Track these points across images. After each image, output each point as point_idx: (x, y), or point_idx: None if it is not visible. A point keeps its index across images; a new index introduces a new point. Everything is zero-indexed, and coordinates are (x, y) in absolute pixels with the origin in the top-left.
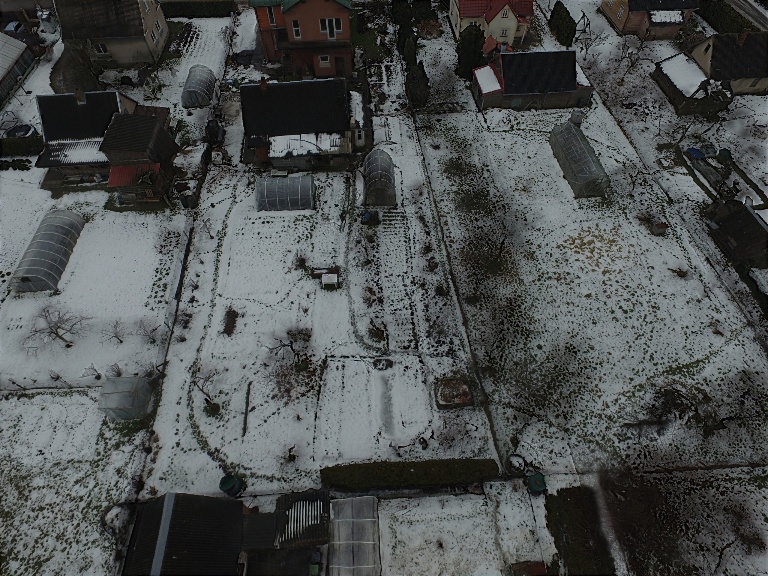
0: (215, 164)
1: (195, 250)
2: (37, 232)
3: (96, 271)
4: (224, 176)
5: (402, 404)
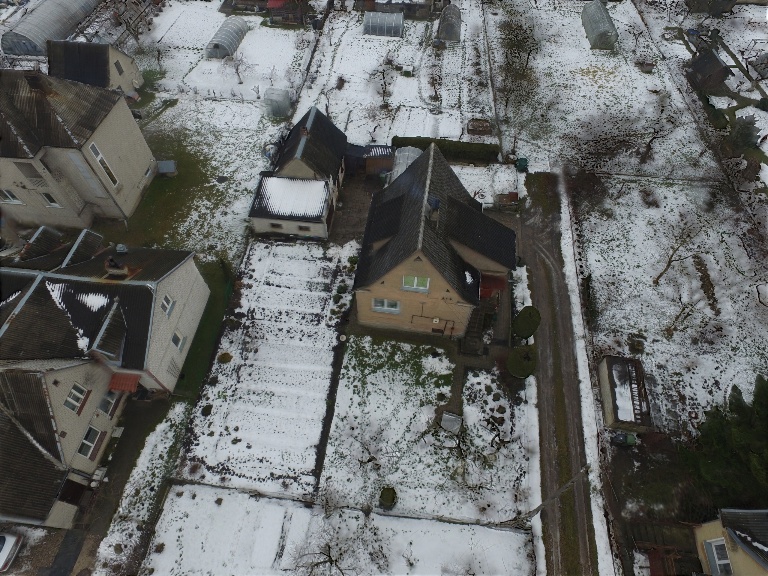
0: (335, 9)
1: (319, 50)
2: (222, 25)
3: (256, 53)
4: (341, 15)
5: (445, 130)
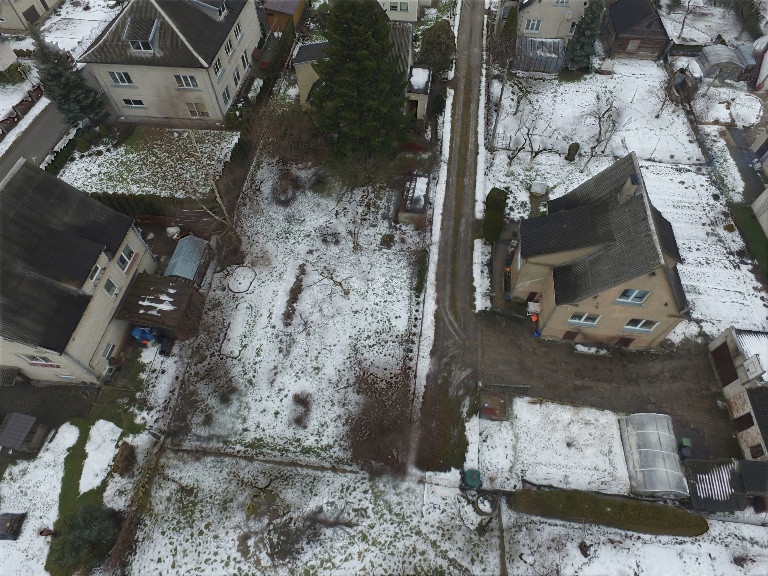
0: None
1: None
2: None
3: None
4: None
5: None
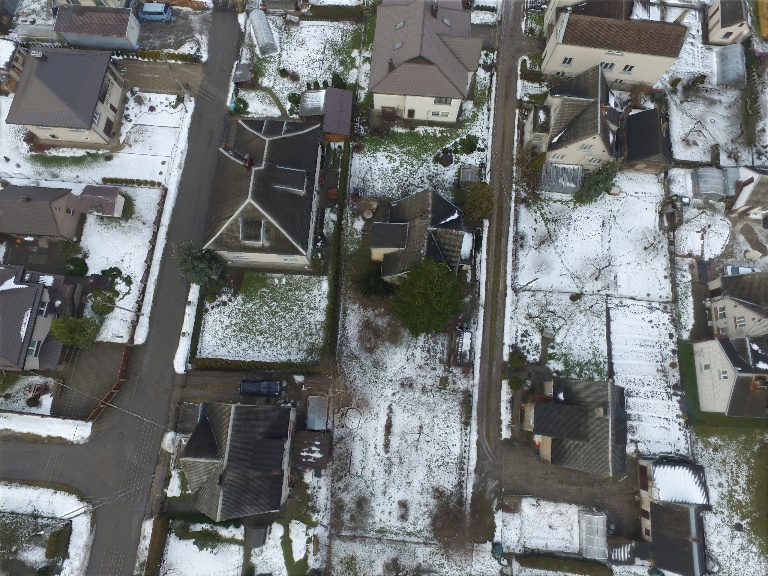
0: None
1: None
2: None
3: None
4: None
5: None
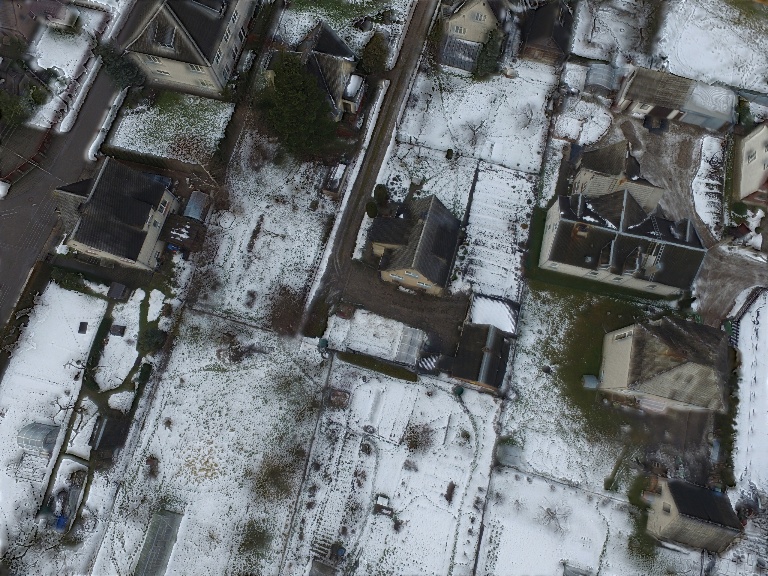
0: None
1: (469, 570)
2: None
3: (539, 573)
4: None
5: (367, 403)
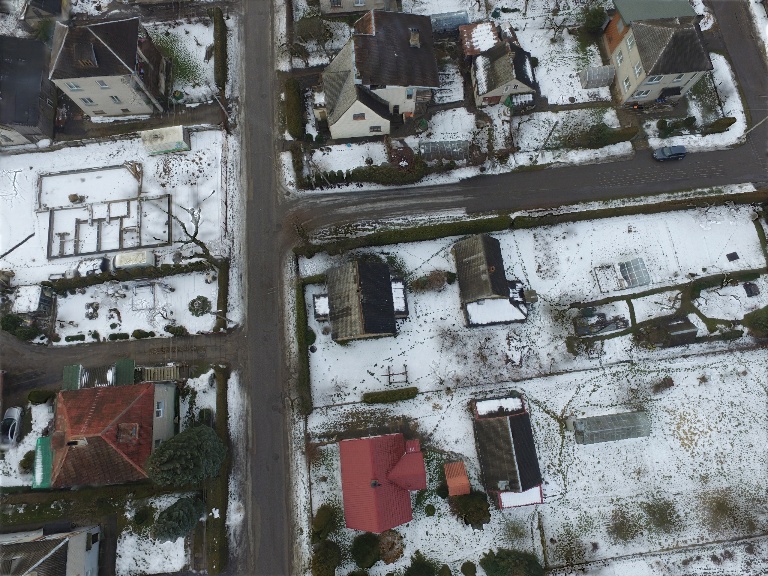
0: None
1: None
2: None
3: None
4: None
5: None
